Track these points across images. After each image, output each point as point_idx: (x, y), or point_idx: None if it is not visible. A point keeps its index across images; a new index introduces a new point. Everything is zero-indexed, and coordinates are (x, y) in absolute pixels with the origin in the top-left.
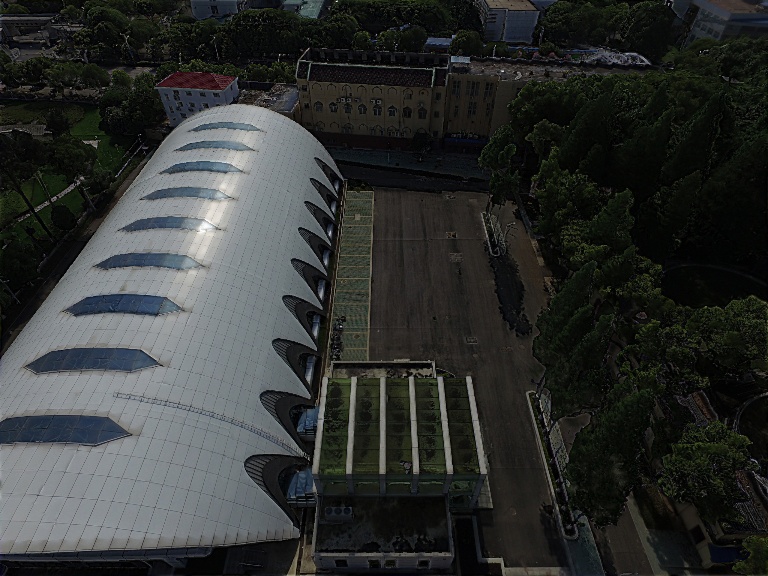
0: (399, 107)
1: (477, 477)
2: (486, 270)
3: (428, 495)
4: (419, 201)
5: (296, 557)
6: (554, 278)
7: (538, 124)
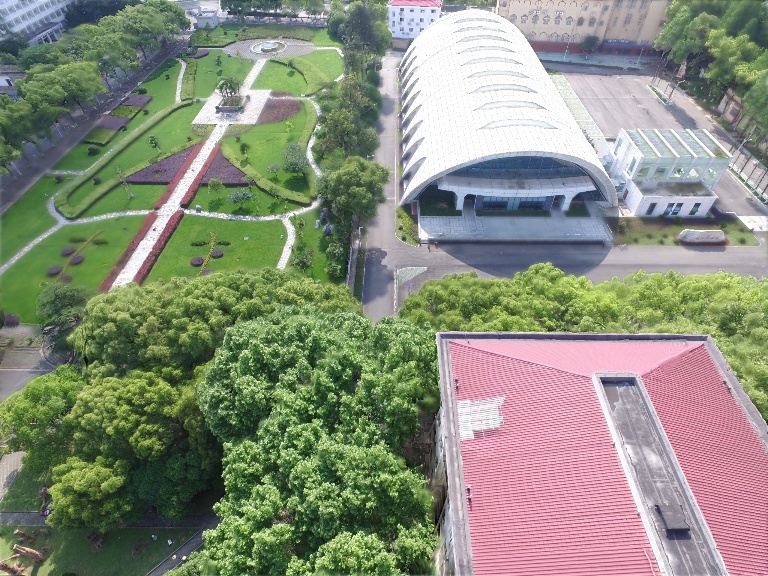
0: (575, 17)
1: (725, 162)
2: (665, 112)
3: (691, 181)
4: (599, 80)
5: (620, 213)
6: (712, 115)
7: (699, 16)
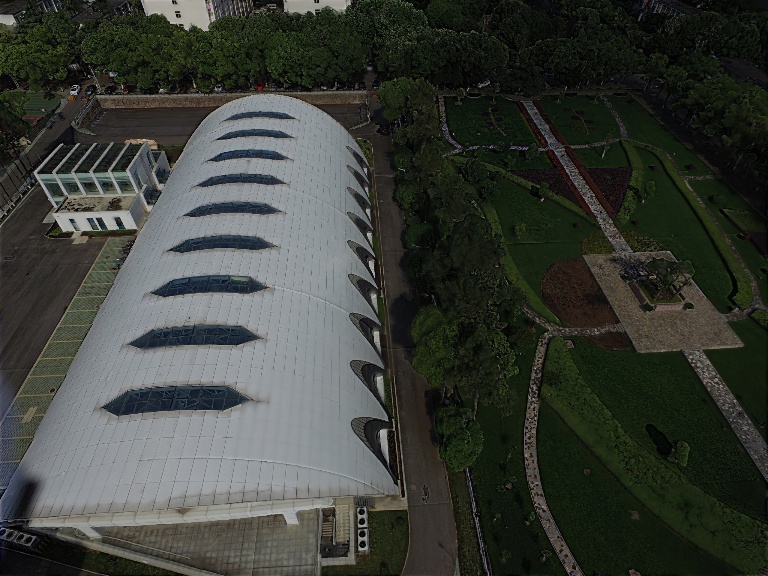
0: None
1: None
2: None
3: None
4: None
5: None
6: None
7: None
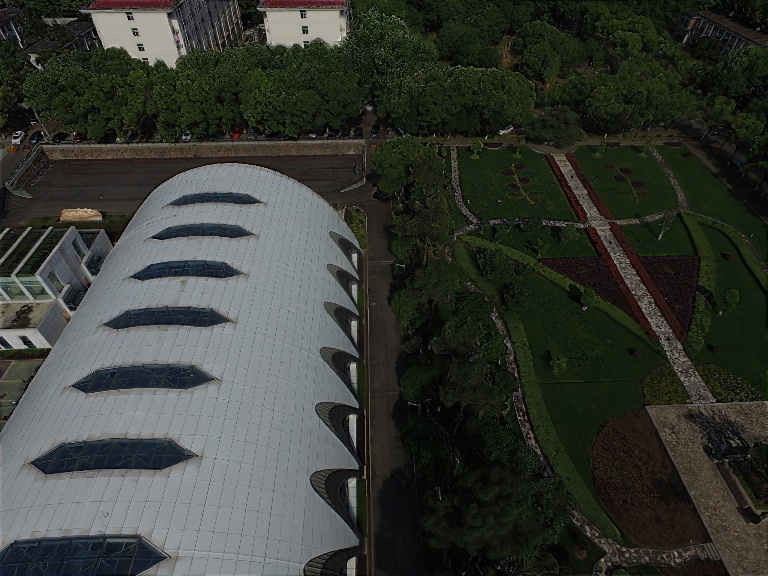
0: None
1: None
2: None
3: None
4: None
5: None
6: None
7: None
